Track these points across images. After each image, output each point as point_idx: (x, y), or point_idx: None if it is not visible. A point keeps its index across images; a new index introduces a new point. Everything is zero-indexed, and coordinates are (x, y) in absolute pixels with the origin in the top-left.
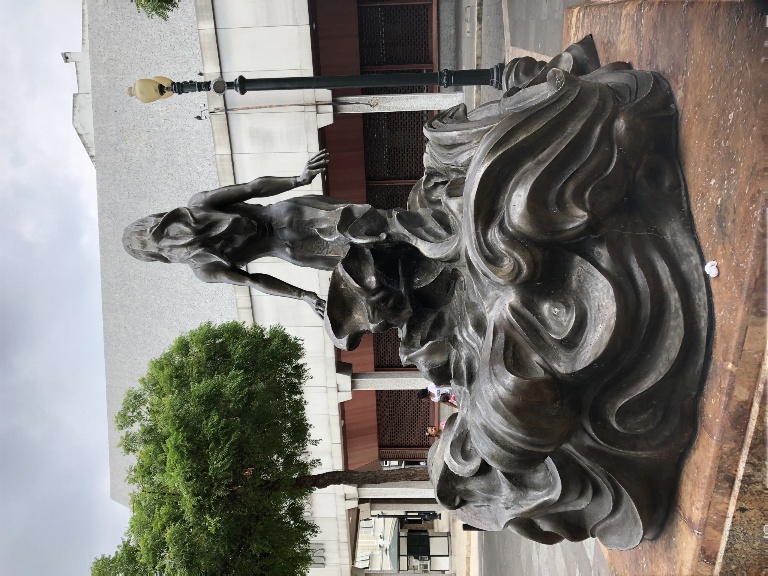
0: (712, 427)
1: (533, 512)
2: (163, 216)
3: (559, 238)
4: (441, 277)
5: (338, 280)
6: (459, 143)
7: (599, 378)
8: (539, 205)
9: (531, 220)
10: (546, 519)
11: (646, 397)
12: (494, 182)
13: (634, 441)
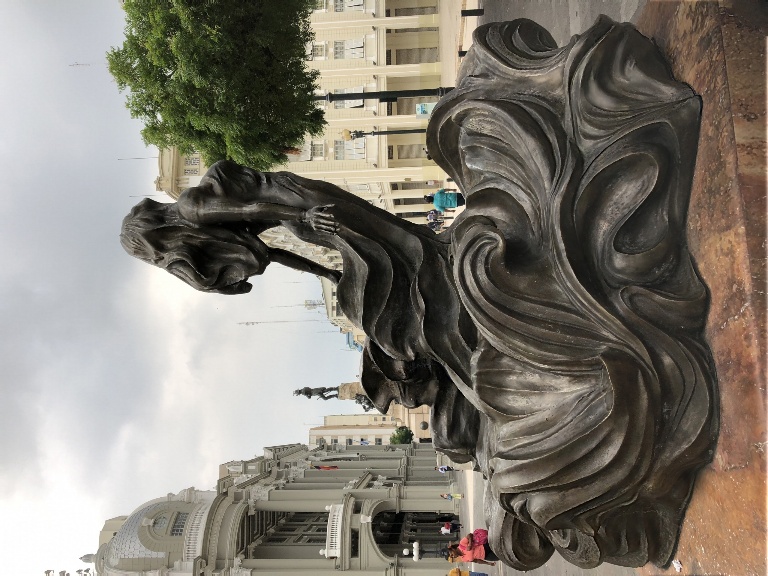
0: (644, 573)
1: None
2: (157, 231)
3: None
4: None
5: (369, 364)
6: None
7: None
8: None
9: None
10: None
11: None
12: None
13: None
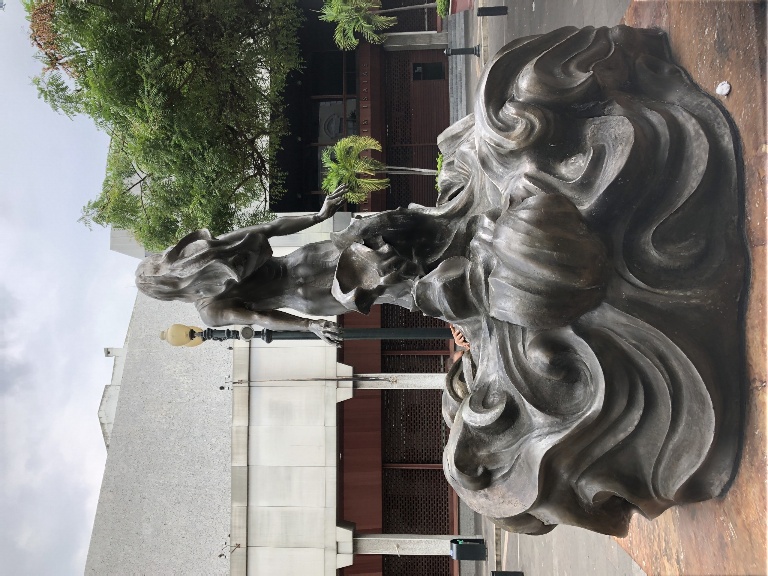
0: (763, 231)
1: (574, 436)
2: None
3: (568, 97)
4: (456, 242)
5: (350, 253)
6: (470, 125)
7: (627, 206)
8: (546, 74)
9: (539, 80)
10: (593, 475)
11: (683, 228)
12: (502, 76)
13: (679, 282)
